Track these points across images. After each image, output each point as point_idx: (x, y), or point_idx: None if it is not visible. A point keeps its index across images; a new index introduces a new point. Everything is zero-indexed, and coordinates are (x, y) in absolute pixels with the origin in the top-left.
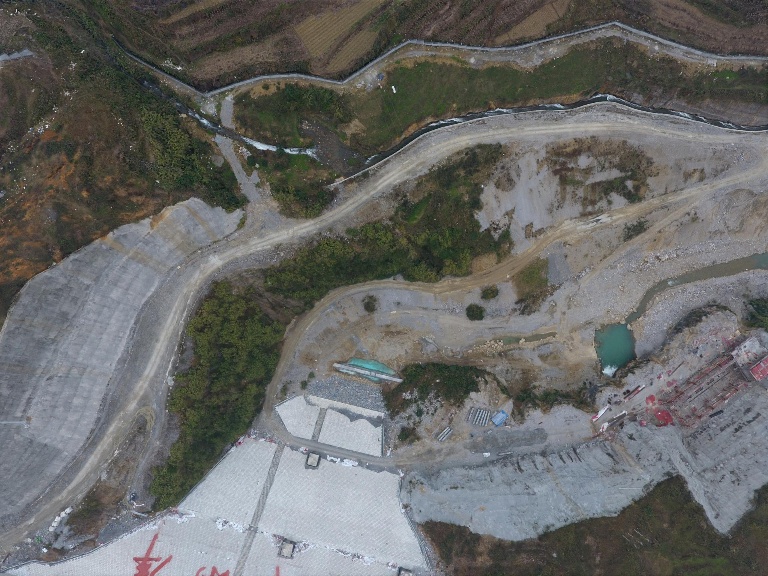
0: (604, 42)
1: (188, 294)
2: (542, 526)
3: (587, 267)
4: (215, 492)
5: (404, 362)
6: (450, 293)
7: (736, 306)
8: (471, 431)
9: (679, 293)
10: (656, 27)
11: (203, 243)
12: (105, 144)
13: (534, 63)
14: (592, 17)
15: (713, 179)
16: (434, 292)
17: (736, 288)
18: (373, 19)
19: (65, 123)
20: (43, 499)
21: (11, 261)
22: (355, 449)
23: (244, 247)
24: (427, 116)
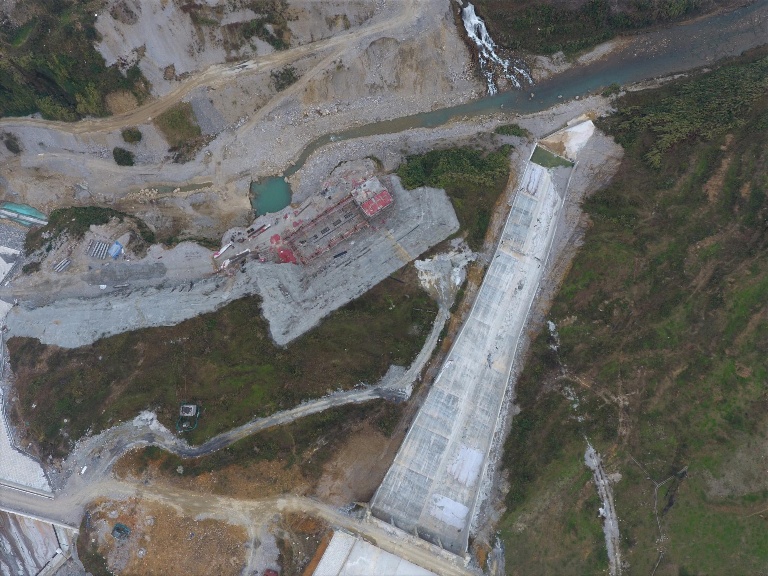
0: None
1: None
2: (99, 333)
3: (242, 117)
4: None
5: (55, 207)
6: (90, 133)
7: (391, 160)
8: (90, 263)
9: (339, 148)
10: None
11: None
12: None
13: None
14: None
15: (359, 27)
16: (74, 132)
17: (395, 144)
18: None
19: None
20: None
21: None
22: None
23: None
24: None
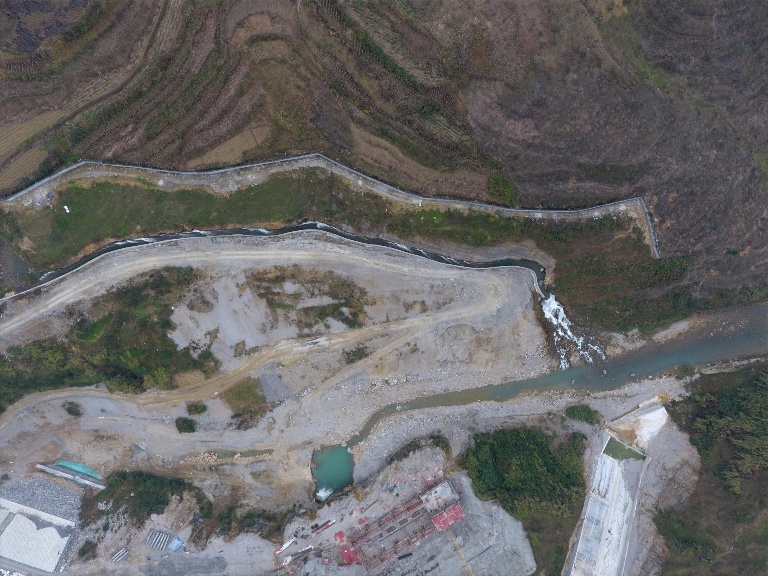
0: (307, 172)
1: None
2: None
3: (309, 387)
4: None
5: (112, 468)
6: (154, 405)
7: (459, 439)
8: (148, 554)
9: (405, 420)
10: (359, 162)
11: None
12: None
13: (229, 189)
14: (295, 146)
15: (436, 311)
16: (138, 403)
17: (463, 420)
18: (45, 137)
19: None
20: None
21: None
22: (27, 562)
23: None
24: (105, 237)
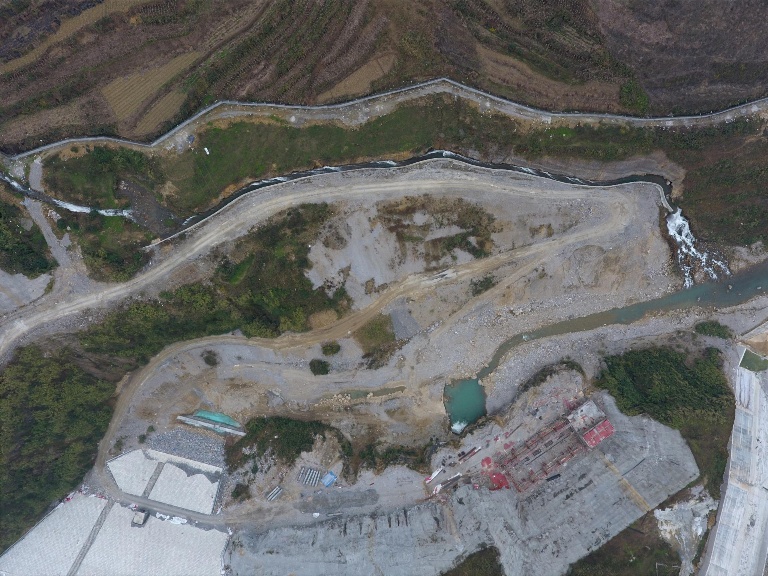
0: (434, 98)
1: None
2: None
3: (436, 321)
4: (31, 552)
5: (249, 415)
6: (290, 349)
7: (590, 363)
8: (301, 491)
9: (533, 348)
10: (486, 83)
11: (8, 308)
12: None
13: (359, 121)
14: (420, 73)
15: (562, 234)
16: (274, 347)
17: (592, 344)
18: (182, 80)
19: None
20: None
21: None
22: (185, 506)
23: (51, 312)
24: (244, 177)
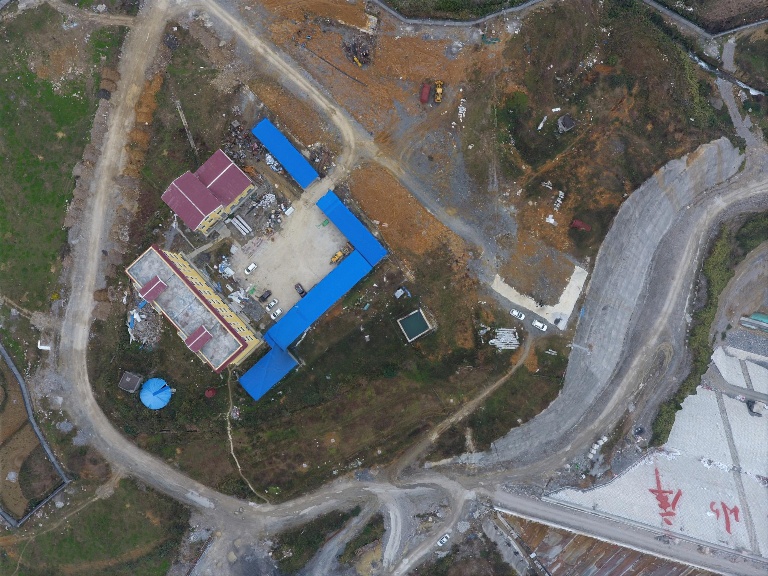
0: None
1: (698, 234)
2: None
3: None
4: (687, 433)
5: None
6: None
7: None
8: None
9: None
10: None
11: (709, 184)
12: (658, 79)
13: None
14: None
15: None
16: None
17: None
18: None
19: (619, 57)
20: (578, 427)
21: (597, 189)
22: None
23: (744, 190)
24: None
